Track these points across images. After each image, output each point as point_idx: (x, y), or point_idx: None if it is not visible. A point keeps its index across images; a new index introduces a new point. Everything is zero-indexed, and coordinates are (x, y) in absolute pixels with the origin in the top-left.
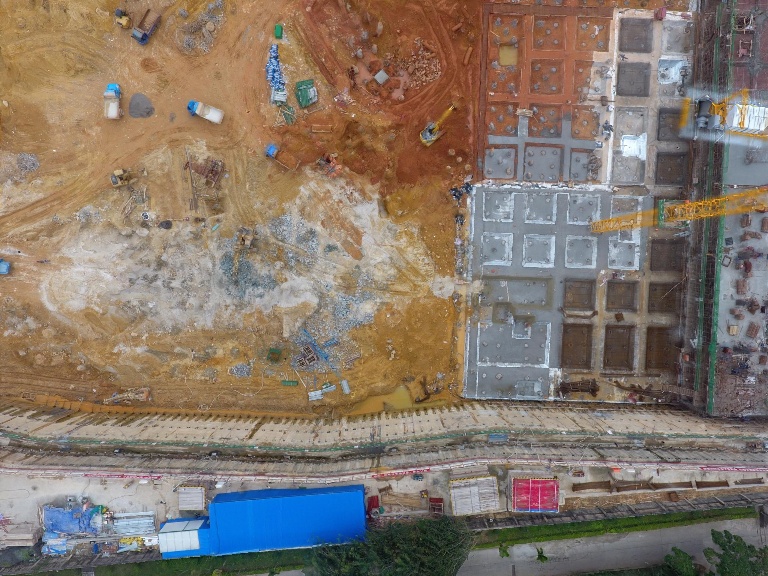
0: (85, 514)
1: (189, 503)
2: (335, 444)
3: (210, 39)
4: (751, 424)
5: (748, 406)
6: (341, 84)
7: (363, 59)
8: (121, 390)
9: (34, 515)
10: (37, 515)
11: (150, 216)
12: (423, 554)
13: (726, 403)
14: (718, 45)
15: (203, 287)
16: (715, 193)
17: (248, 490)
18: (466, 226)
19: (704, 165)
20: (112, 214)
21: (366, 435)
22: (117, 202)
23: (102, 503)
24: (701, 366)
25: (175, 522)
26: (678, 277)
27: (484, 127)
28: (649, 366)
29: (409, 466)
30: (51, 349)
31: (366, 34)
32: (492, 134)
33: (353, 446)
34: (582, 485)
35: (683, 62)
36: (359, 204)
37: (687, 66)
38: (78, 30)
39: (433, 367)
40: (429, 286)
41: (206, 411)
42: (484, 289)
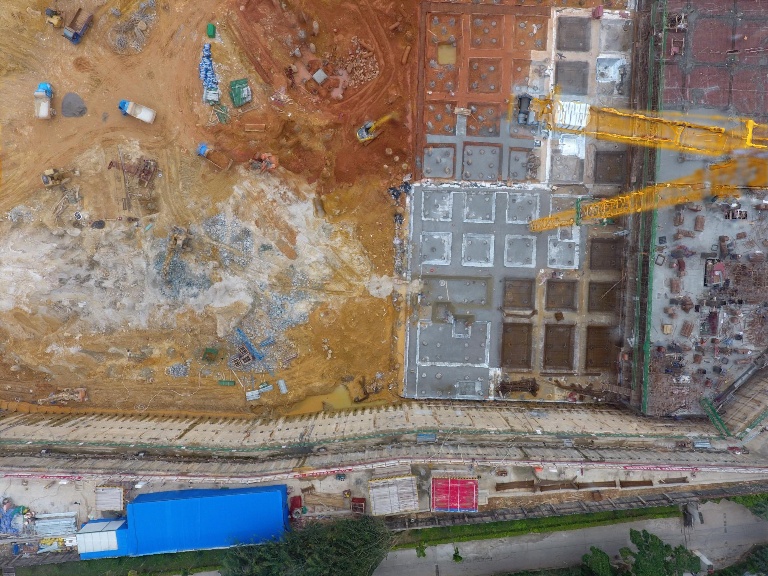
0: (6, 515)
1: (107, 503)
2: (263, 444)
3: (142, 38)
4: (685, 423)
5: (683, 405)
6: (278, 83)
7: (302, 58)
8: (58, 390)
9: None
10: None
11: (83, 216)
12: (335, 554)
13: (661, 402)
14: (652, 43)
15: (136, 287)
16: (649, 192)
17: (170, 490)
18: (405, 225)
19: (640, 164)
20: (44, 214)
21: (296, 435)
22: (50, 202)
23: (23, 504)
24: (637, 365)
25: (96, 523)
26: (617, 276)
27: (422, 126)
28: (590, 365)
29: (332, 466)
30: None
31: (303, 33)
32: (431, 133)
33: (281, 446)
34: (505, 485)
35: (621, 61)
36: (293, 203)
37: (625, 65)
38: (9, 29)
39: (372, 367)
40: (365, 285)
41: (144, 411)
42: (424, 288)
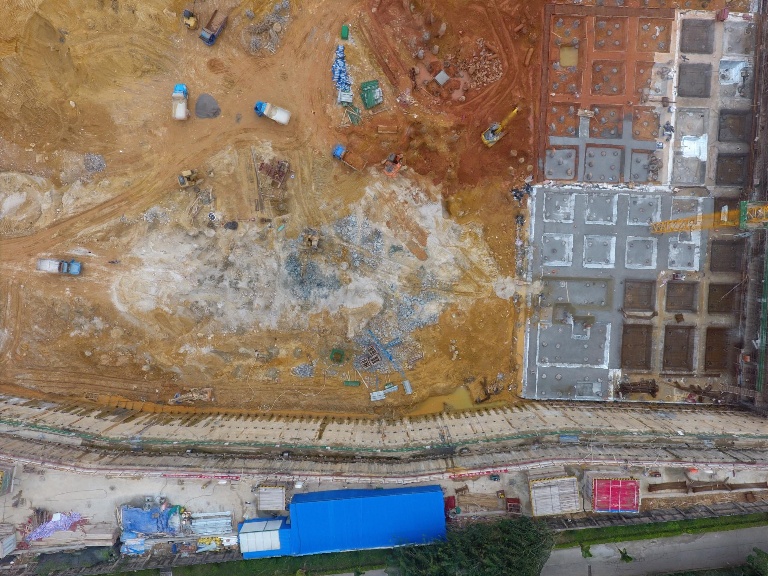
0: (163, 514)
1: (270, 503)
2: (406, 444)
3: (277, 40)
4: None
5: None
6: (403, 85)
7: (423, 60)
8: (183, 390)
9: (112, 515)
10: (115, 515)
11: (216, 217)
12: (510, 554)
13: None
14: None
15: (269, 287)
16: None
17: (325, 490)
18: (526, 227)
19: (767, 166)
20: (179, 215)
21: (435, 435)
22: (183, 203)
23: (179, 503)
24: (764, 367)
25: (253, 522)
26: (738, 278)
27: (545, 128)
28: (708, 367)
29: (485, 466)
30: (117, 349)
31: (428, 35)
32: (553, 135)
33: (424, 446)
34: (658, 486)
35: (744, 63)
36: (424, 205)
37: (748, 67)
38: (146, 31)
39: (494, 367)
40: (493, 287)
41: (268, 411)
42: (544, 290)
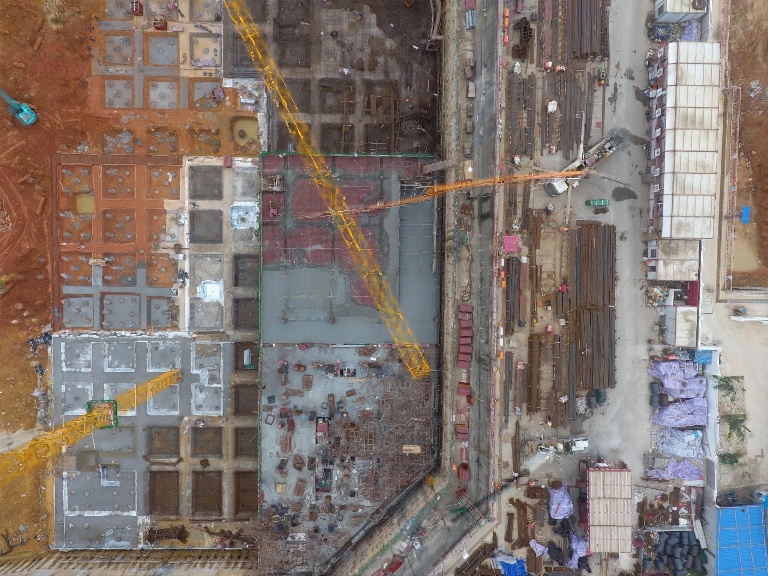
0: None
1: None
2: None
3: None
4: None
5: (299, 563)
6: None
7: None
8: None
9: None
10: None
11: None
12: None
13: (277, 561)
14: None
15: None
16: None
17: None
18: (48, 375)
19: None
20: None
21: None
22: None
23: None
24: None
25: None
26: None
27: (58, 277)
28: (241, 510)
29: None
30: None
31: None
32: (68, 283)
33: None
34: None
35: (256, 208)
36: None
37: None
38: None
39: (13, 520)
40: None
41: None
42: None
